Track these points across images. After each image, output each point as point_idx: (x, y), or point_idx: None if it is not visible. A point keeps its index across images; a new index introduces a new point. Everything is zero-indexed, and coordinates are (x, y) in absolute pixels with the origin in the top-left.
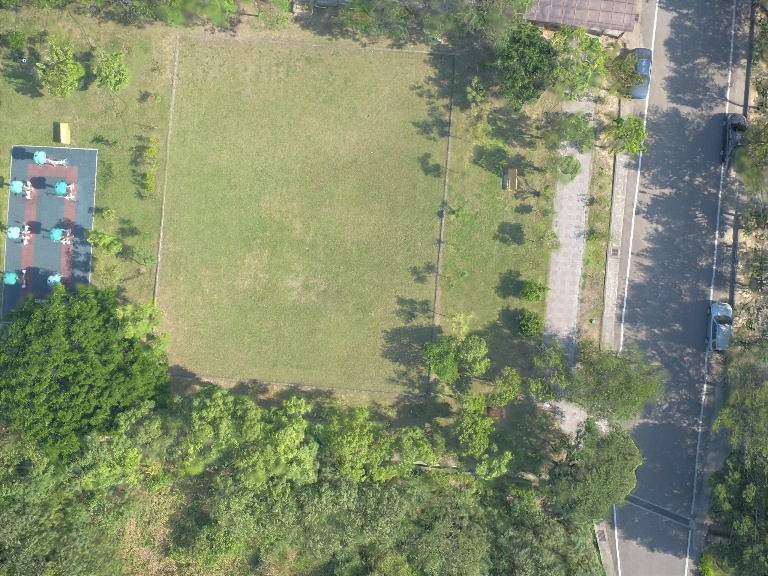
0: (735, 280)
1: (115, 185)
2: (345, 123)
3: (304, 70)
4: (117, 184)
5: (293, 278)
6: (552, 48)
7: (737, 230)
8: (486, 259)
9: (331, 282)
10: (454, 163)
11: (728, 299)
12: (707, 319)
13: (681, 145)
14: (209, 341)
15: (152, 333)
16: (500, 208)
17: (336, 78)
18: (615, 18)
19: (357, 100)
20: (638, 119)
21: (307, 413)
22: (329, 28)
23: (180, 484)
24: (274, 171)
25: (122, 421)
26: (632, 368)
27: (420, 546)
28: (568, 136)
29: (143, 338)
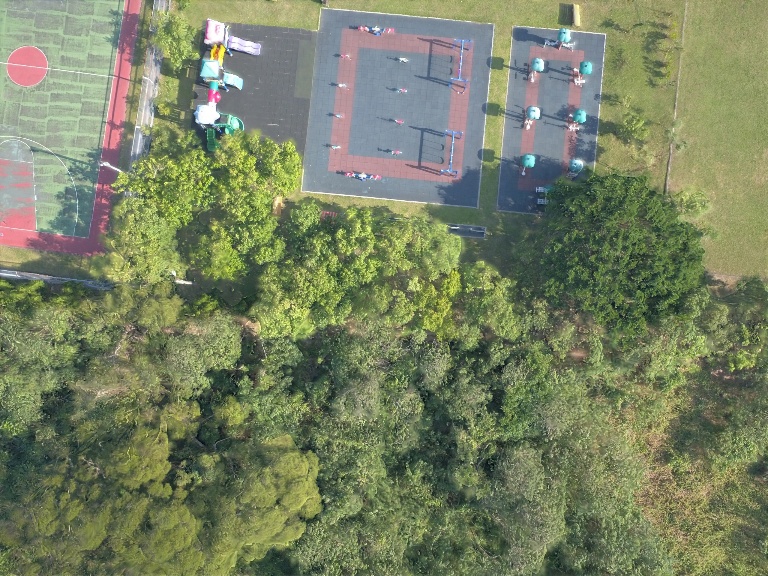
0: None
1: (625, 72)
2: None
3: None
4: (628, 71)
5: None
6: None
7: None
8: None
9: None
10: None
11: None
12: None
13: None
14: (723, 237)
15: None
16: None
17: None
18: None
19: None
20: None
21: None
22: None
23: (687, 387)
24: None
25: (694, 306)
26: None
27: None
28: None
29: None
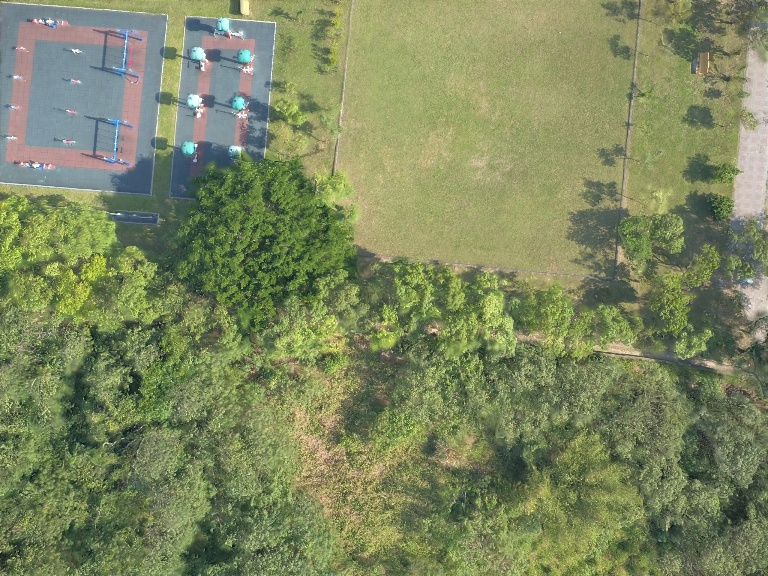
0: None
1: (294, 59)
2: (533, 3)
3: None
4: (296, 58)
5: (478, 158)
6: None
7: None
8: (674, 143)
9: (517, 162)
10: (643, 46)
11: None
12: None
13: None
14: (390, 220)
15: (340, 205)
16: (689, 92)
17: None
18: None
19: None
20: None
21: None
22: None
23: (356, 367)
24: (460, 49)
25: (321, 286)
26: None
27: (609, 430)
28: (759, 21)
29: (333, 208)
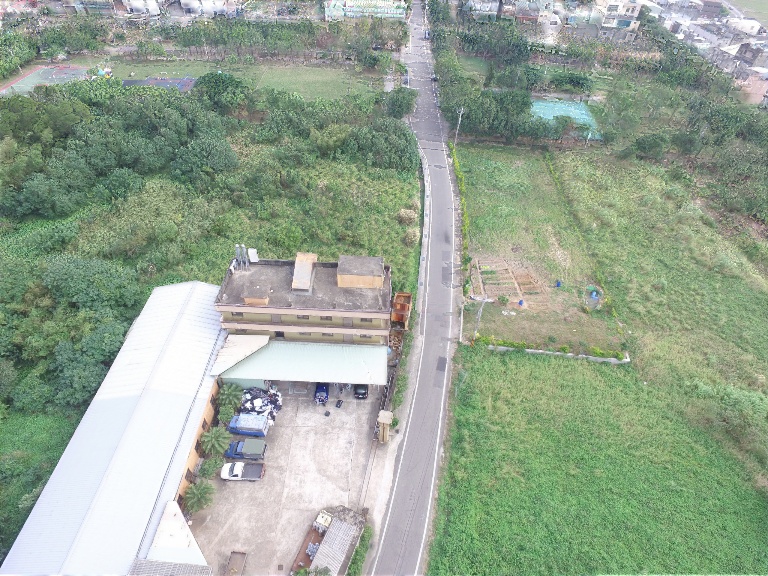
0: None
1: None
2: None
3: None
4: None
5: None
6: None
7: None
8: None
9: None
10: None
11: None
12: None
13: None
14: None
15: None
16: None
17: None
18: (395, 59)
19: None
20: None
21: None
22: None
23: None
24: None
25: None
26: None
27: None
28: (386, 80)
29: None
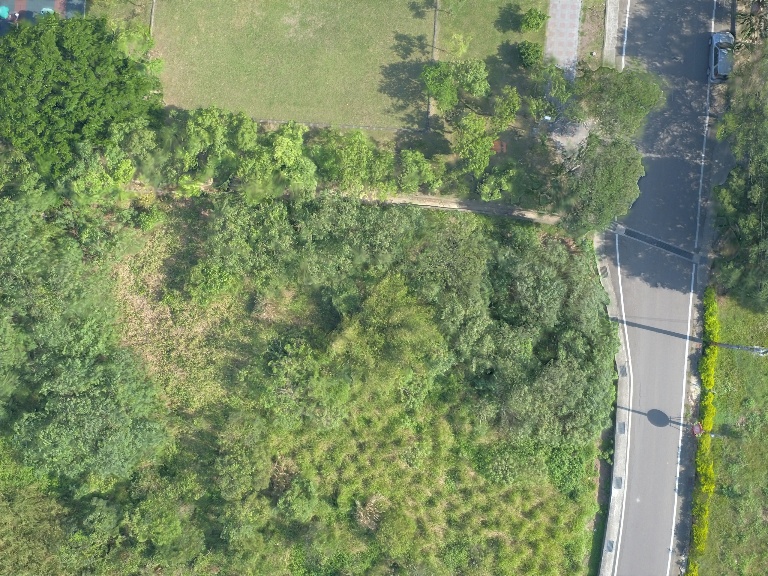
0: (736, 11)
1: None
2: None
3: None
4: None
5: (290, 15)
6: None
7: None
8: None
9: (329, 19)
10: None
11: (729, 31)
12: (709, 49)
13: None
14: (205, 80)
15: (147, 60)
16: None
17: None
18: None
19: None
20: None
21: None
22: None
23: (175, 226)
24: None
25: (116, 130)
26: None
27: (420, 277)
28: None
29: None
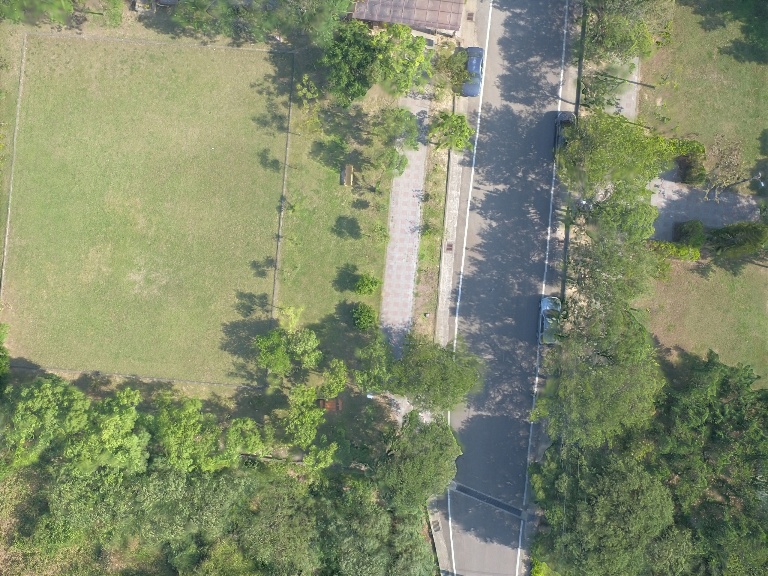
0: (566, 275)
1: None
2: (187, 120)
3: (148, 67)
4: None
5: (135, 272)
6: (376, 46)
7: (569, 226)
8: (323, 254)
9: (172, 276)
10: (293, 159)
11: (560, 293)
12: (538, 313)
13: (514, 142)
14: (53, 334)
15: None
16: (337, 203)
17: (179, 75)
18: (442, 17)
19: (199, 97)
20: (461, 116)
21: (149, 405)
22: (172, 26)
23: (24, 474)
24: (118, 167)
25: None
26: (466, 361)
27: None
28: (403, 133)
29: None
